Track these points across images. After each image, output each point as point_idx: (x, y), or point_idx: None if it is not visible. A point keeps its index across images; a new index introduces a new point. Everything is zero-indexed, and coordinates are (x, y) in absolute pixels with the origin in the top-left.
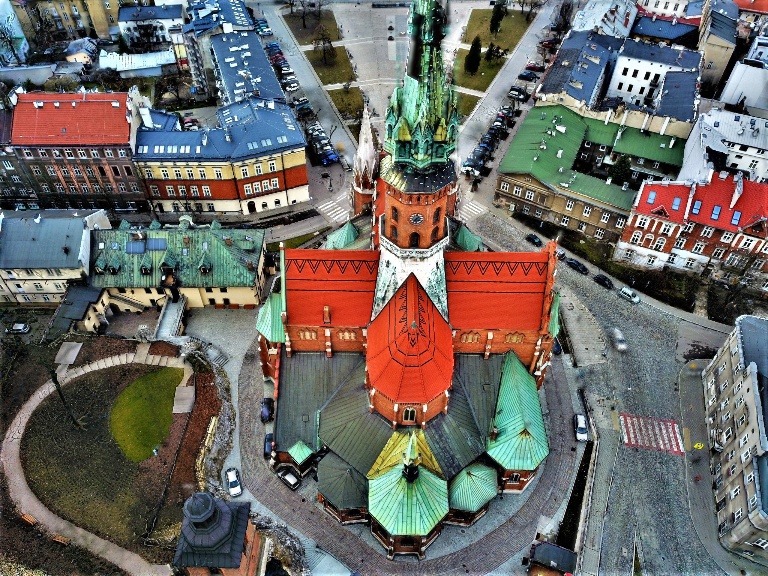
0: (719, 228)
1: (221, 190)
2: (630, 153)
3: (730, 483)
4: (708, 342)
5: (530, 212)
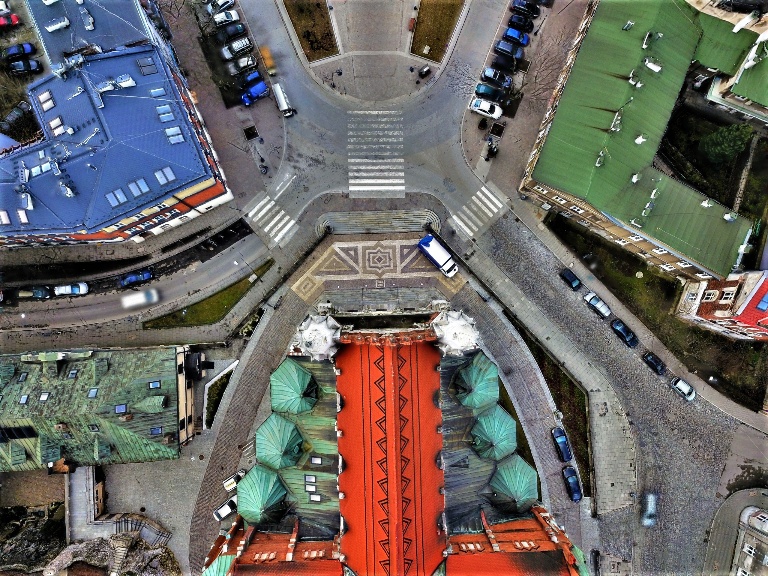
0: None
1: (88, 236)
2: (757, 100)
3: None
4: (763, 460)
5: (573, 217)
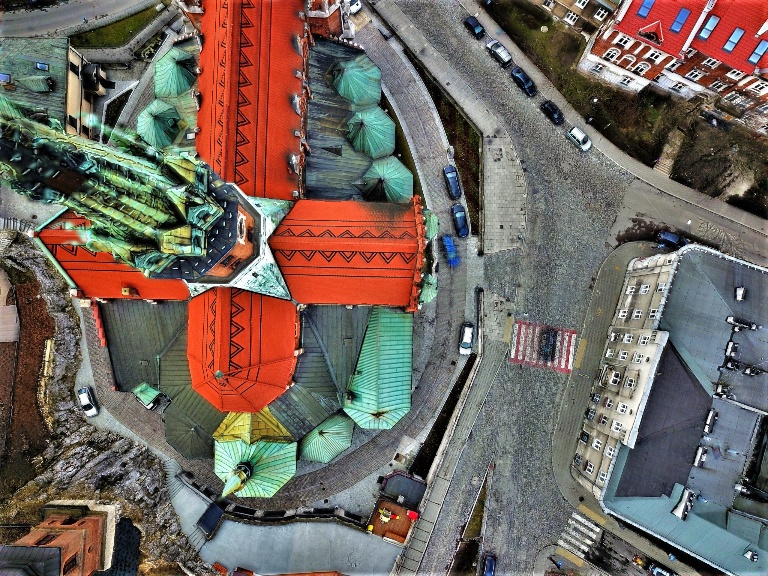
0: (728, 65)
1: None
2: None
3: (597, 430)
4: (655, 215)
5: None
